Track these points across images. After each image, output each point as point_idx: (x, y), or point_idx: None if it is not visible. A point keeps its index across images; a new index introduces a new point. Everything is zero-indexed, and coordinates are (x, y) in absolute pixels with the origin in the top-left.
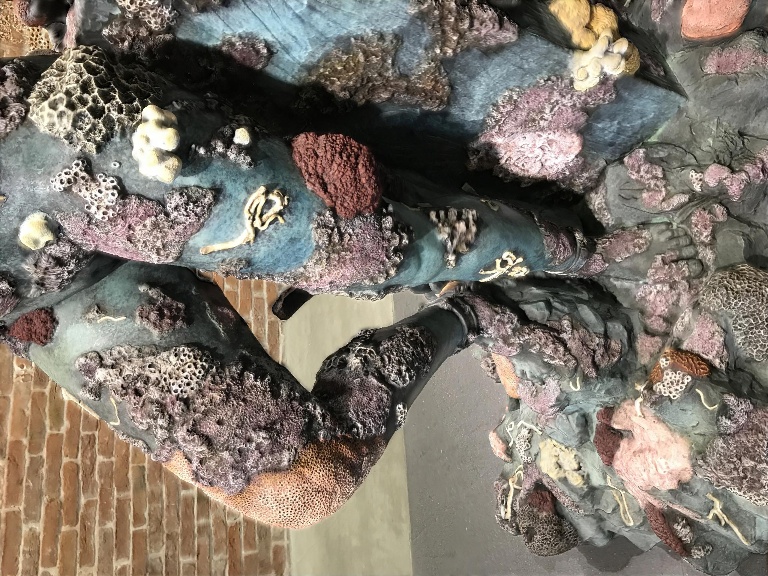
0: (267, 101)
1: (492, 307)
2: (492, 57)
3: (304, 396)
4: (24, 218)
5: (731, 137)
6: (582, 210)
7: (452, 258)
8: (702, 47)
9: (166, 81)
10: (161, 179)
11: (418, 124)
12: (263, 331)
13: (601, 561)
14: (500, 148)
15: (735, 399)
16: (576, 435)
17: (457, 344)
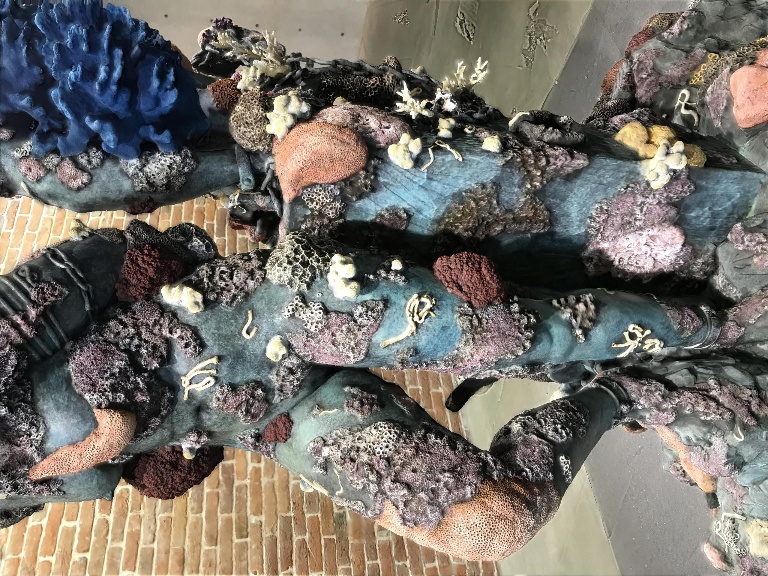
0: (414, 252)
1: (638, 381)
2: (574, 181)
3: (477, 450)
4: (268, 341)
5: None
6: (711, 293)
7: (579, 332)
8: (762, 132)
9: (343, 244)
10: (348, 299)
11: (532, 246)
12: None
13: None
14: (609, 252)
15: None
16: None
17: (613, 416)
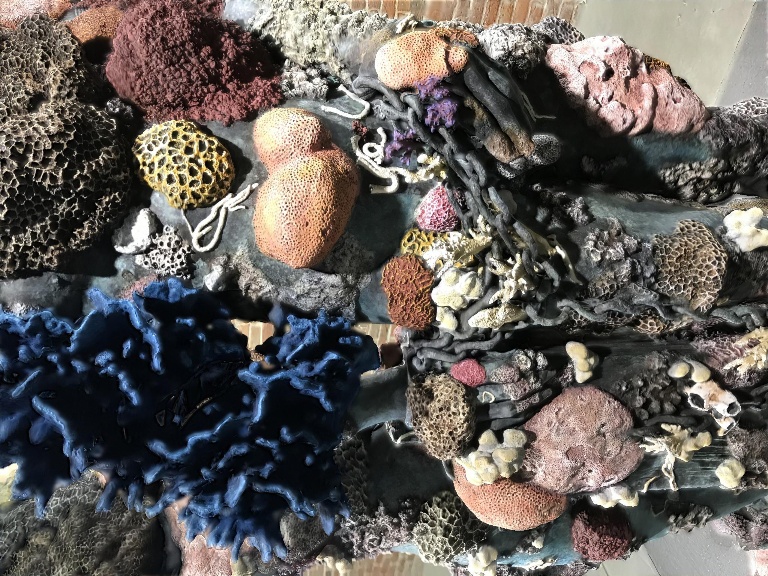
0: None
1: None
2: None
3: (535, 575)
4: None
5: None
6: None
7: None
8: None
9: None
10: None
11: None
12: None
13: None
14: None
15: None
16: None
17: None
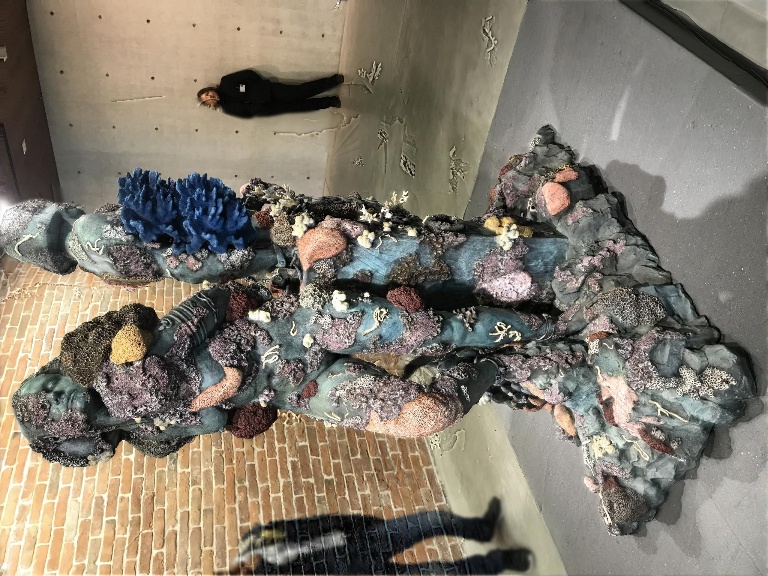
0: None
1: (509, 356)
2: (460, 250)
3: None
4: (304, 337)
5: (591, 245)
6: (555, 311)
7: (468, 325)
8: (563, 217)
9: None
10: (343, 312)
11: (444, 288)
12: (448, 554)
13: (672, 517)
14: (489, 289)
15: (620, 339)
16: (596, 420)
17: (495, 374)
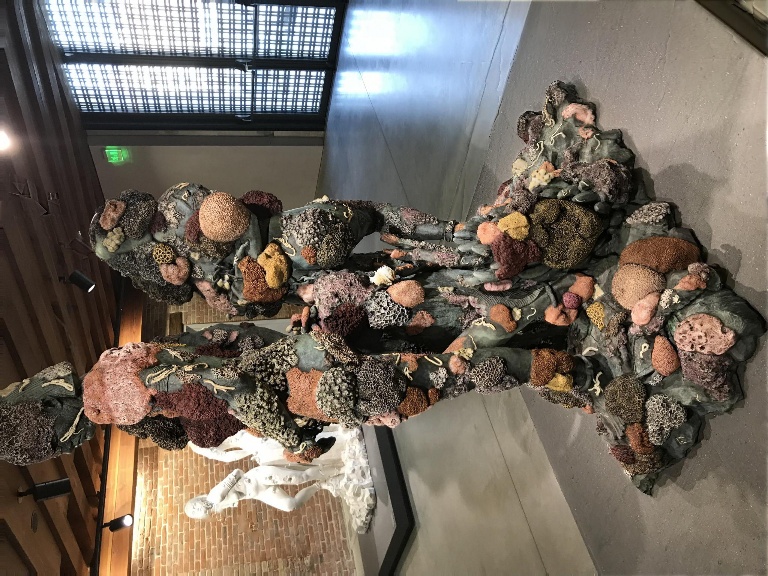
0: None
1: None
2: None
3: None
4: None
5: None
6: None
7: None
8: None
9: None
10: None
11: None
12: None
13: None
14: None
15: None
16: None
17: None
